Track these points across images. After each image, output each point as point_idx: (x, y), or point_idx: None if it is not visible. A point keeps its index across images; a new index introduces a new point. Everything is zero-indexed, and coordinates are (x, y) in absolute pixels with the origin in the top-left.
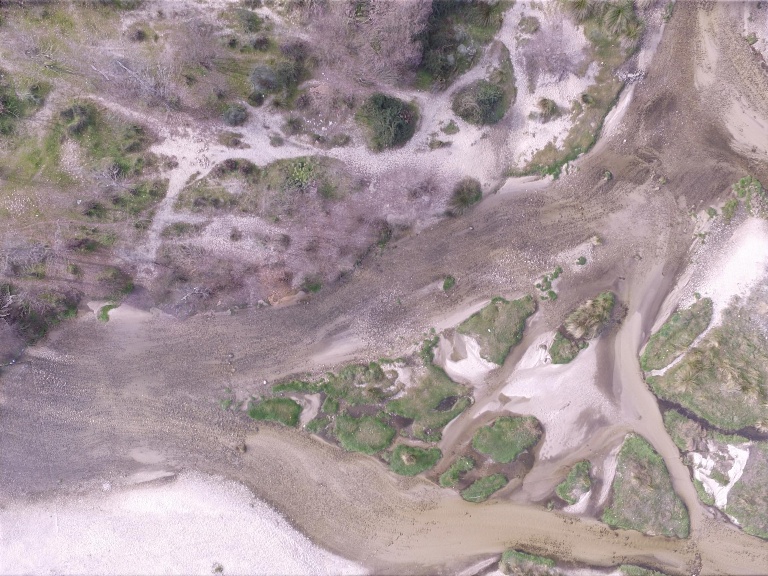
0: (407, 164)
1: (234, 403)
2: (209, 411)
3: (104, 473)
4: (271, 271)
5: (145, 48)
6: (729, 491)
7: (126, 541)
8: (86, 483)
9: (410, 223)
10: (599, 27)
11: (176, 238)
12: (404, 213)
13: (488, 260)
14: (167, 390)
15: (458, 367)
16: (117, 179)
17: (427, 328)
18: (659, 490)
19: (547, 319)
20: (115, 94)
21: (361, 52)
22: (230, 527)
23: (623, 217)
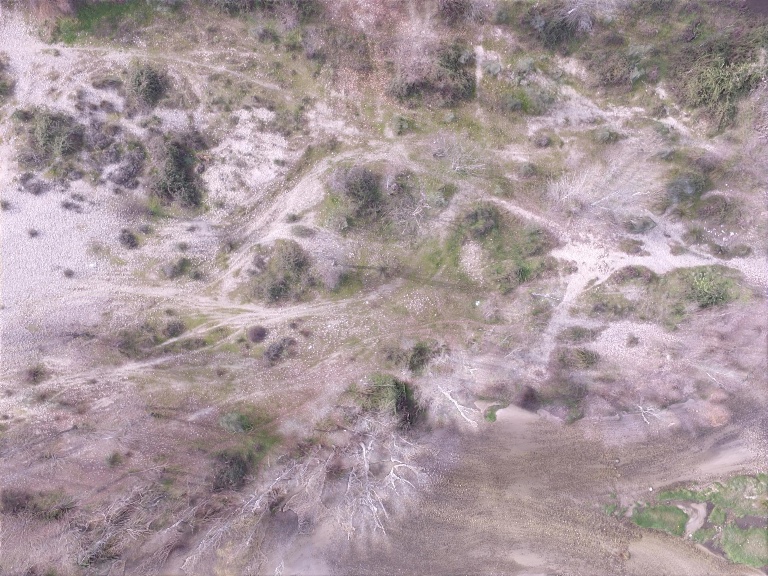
0: None
1: (619, 509)
2: (592, 515)
3: (484, 573)
4: (663, 378)
5: (550, 154)
6: None
7: None
8: None
9: None
10: None
11: (571, 342)
12: None
13: None
14: (551, 492)
15: None
16: (518, 282)
17: None
18: None
19: None
20: (517, 198)
21: (767, 165)
22: None
23: None
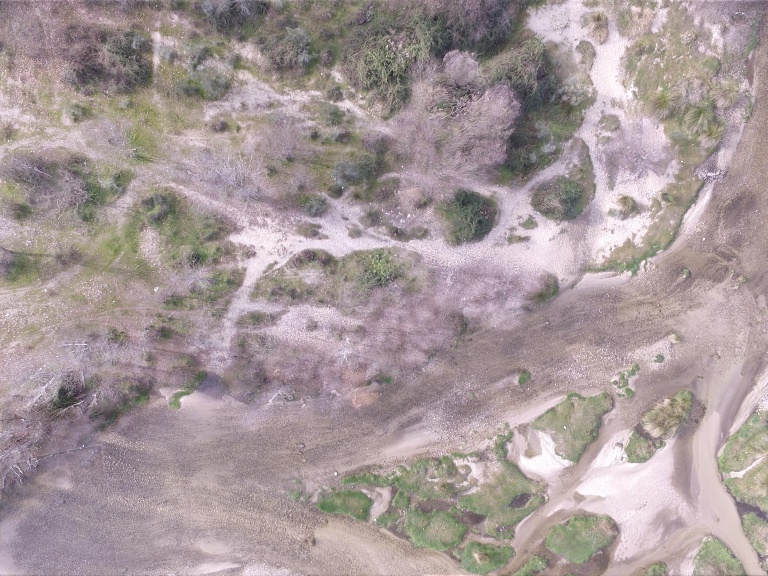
0: (484, 258)
1: (304, 494)
2: (278, 501)
3: (170, 562)
4: (345, 361)
5: (227, 138)
6: None
7: None
8: (152, 572)
9: (486, 316)
10: (679, 126)
11: (251, 327)
12: (480, 306)
13: (564, 355)
14: (237, 479)
15: (532, 463)
16: (195, 267)
17: (501, 423)
18: None
19: (624, 417)
20: (195, 183)
21: (441, 147)
22: None
23: (701, 315)
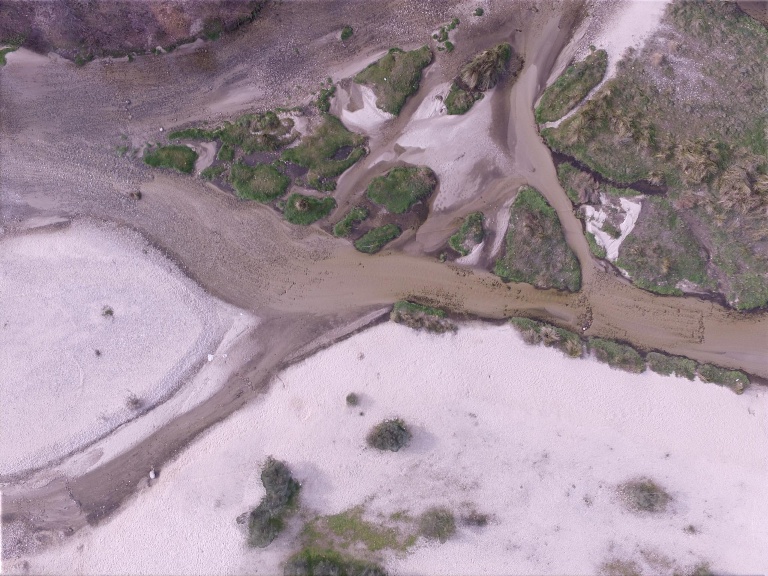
0: None
1: (130, 150)
2: (105, 158)
3: None
4: (169, 17)
5: None
6: (620, 244)
7: (17, 283)
8: None
9: None
10: None
11: None
12: None
13: (386, 11)
14: (63, 136)
15: (354, 116)
16: None
17: (324, 78)
18: (551, 241)
19: (443, 70)
20: None
21: None
22: (122, 271)
23: None
